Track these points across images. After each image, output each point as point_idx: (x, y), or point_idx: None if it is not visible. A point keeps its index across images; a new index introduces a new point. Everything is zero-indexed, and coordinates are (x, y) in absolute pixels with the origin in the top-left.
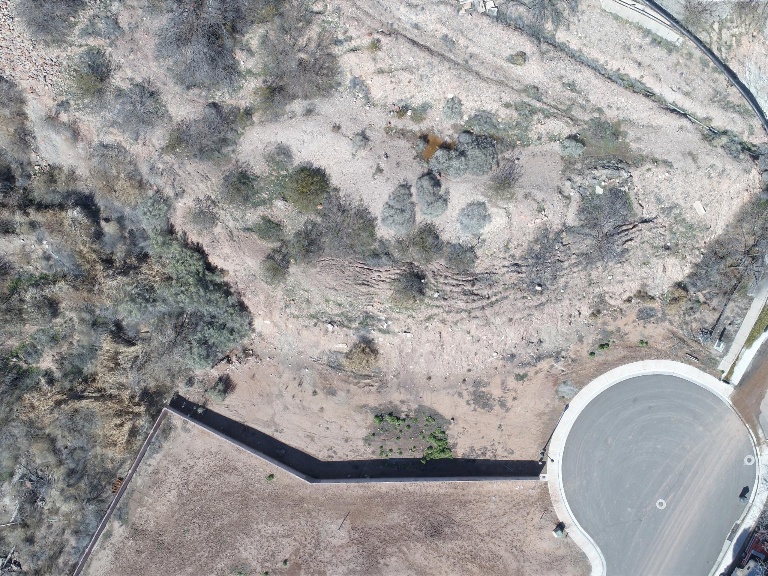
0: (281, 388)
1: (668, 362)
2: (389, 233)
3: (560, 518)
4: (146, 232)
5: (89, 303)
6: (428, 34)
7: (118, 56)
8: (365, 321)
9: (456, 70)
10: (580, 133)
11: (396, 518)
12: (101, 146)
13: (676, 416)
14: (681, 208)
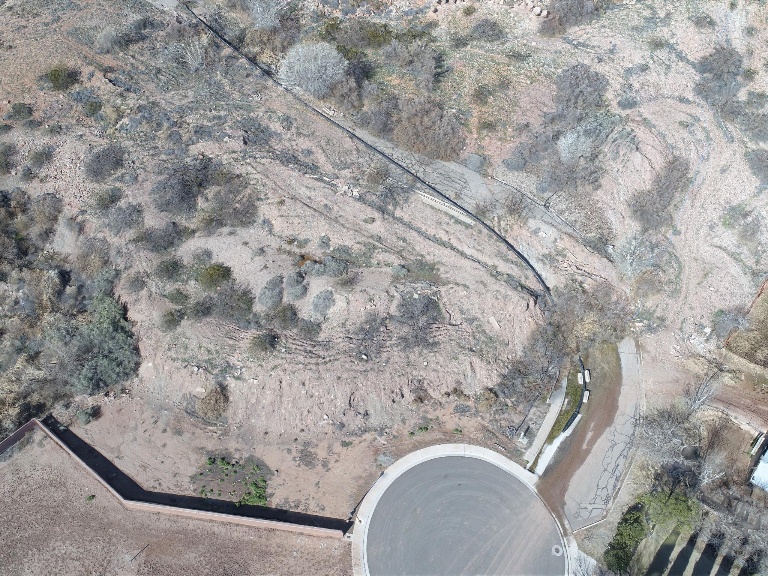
0: (138, 423)
1: (478, 448)
2: (262, 309)
3: None
4: None
5: (25, 337)
6: (316, 203)
7: (129, 191)
8: (225, 369)
9: (329, 221)
10: (407, 265)
11: (192, 559)
12: (93, 239)
13: (484, 496)
14: (481, 321)
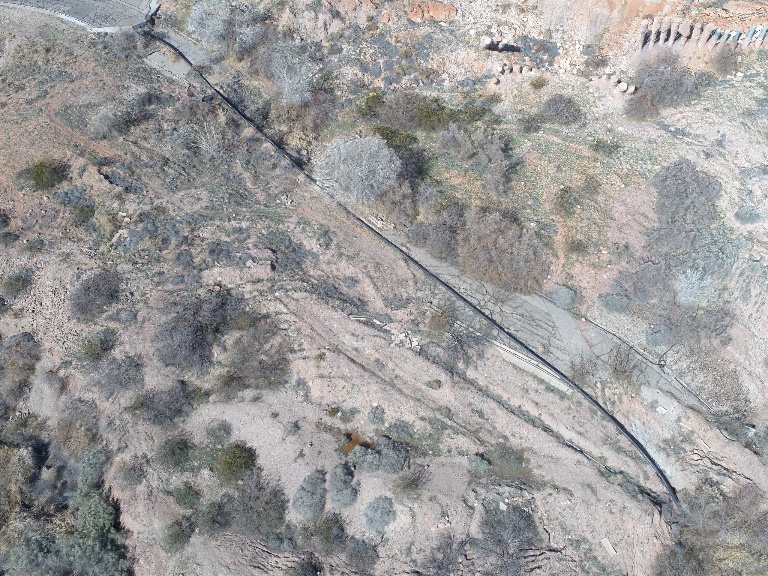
0: None
1: None
2: (297, 518)
3: None
4: (77, 486)
5: None
6: (364, 356)
7: (125, 336)
8: None
9: (382, 384)
10: (487, 453)
11: None
12: (78, 401)
13: None
14: (590, 543)
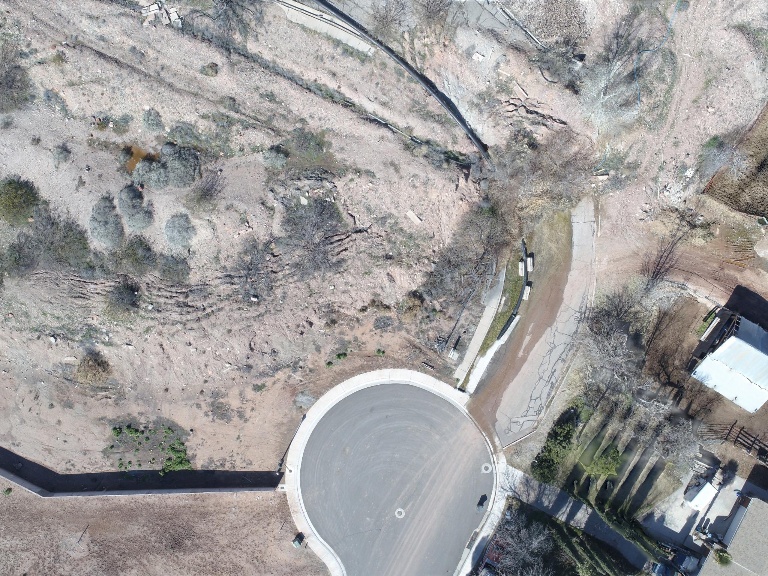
0: (17, 401)
1: (404, 371)
2: (102, 245)
3: (299, 528)
4: None
5: None
6: (116, 46)
7: None
8: (88, 334)
9: (147, 82)
10: (284, 144)
11: (136, 530)
12: None
13: (413, 425)
14: (395, 218)
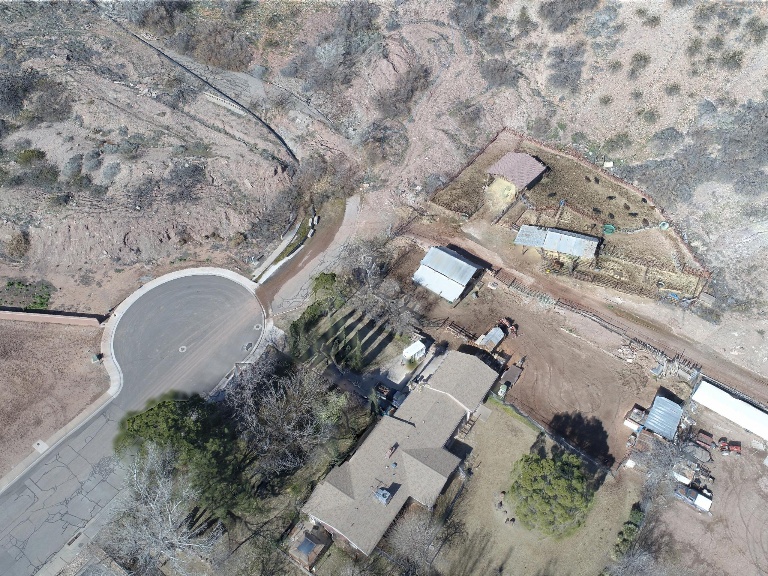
0: None
1: (220, 269)
2: (65, 179)
3: (102, 351)
4: None
5: None
6: (120, 102)
7: None
8: (29, 221)
9: (128, 115)
10: (187, 146)
11: None
12: None
13: (214, 297)
14: (238, 183)
